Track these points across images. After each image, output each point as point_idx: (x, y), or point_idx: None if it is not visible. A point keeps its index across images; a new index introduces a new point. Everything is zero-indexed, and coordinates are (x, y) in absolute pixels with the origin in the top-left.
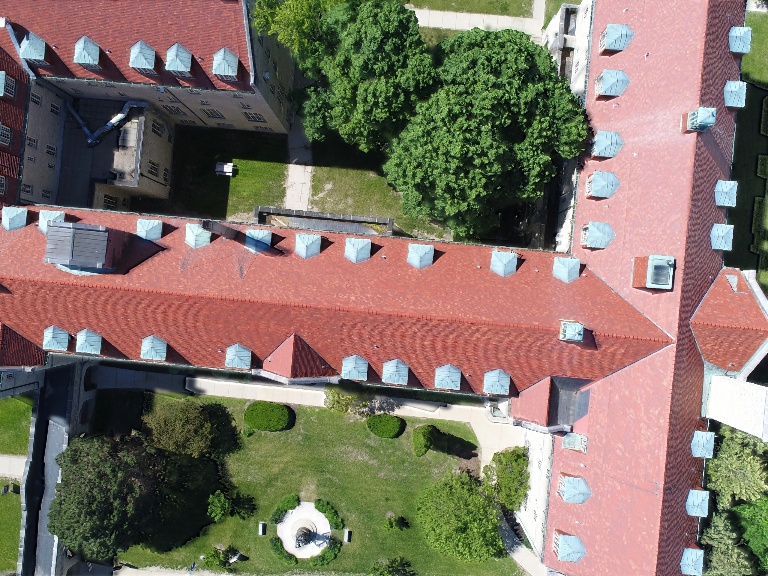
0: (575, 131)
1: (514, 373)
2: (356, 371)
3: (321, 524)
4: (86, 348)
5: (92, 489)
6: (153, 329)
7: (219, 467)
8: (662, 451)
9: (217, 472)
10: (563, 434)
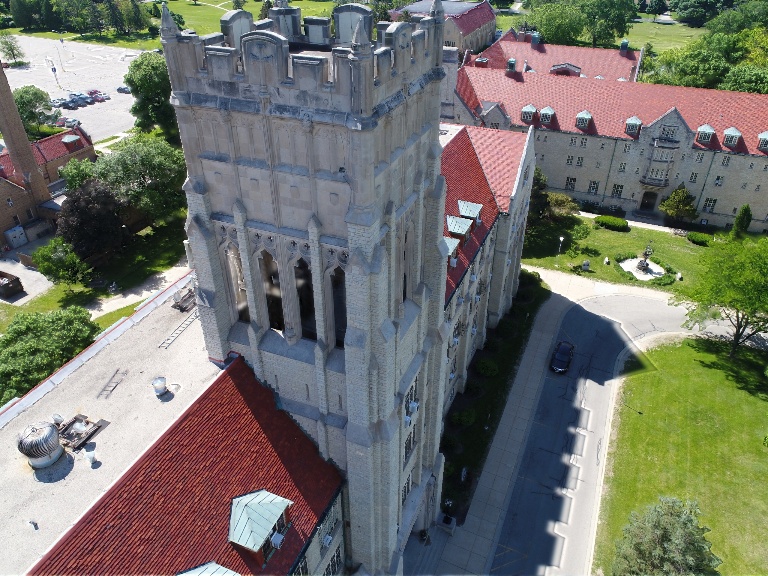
0: None
1: None
2: (708, 128)
3: (656, 268)
4: (546, 111)
5: None
6: (589, 106)
7: None
8: None
9: None
10: None
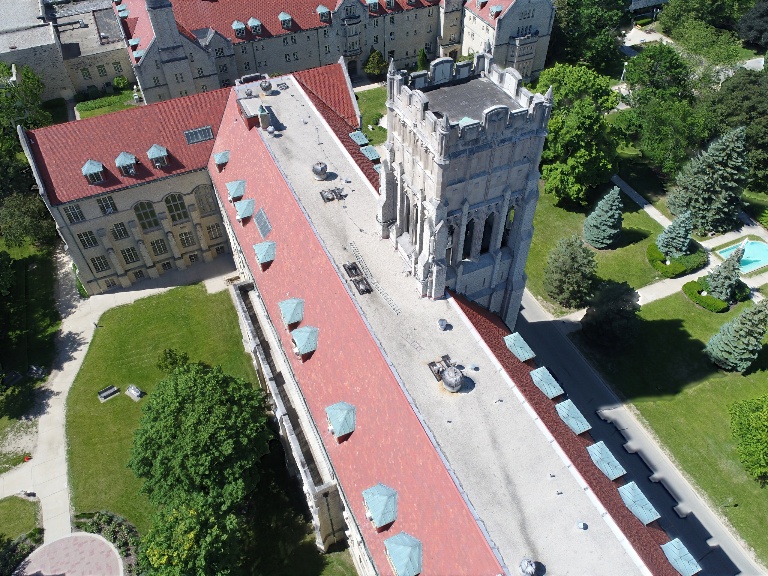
0: None
1: None
2: None
3: None
4: (254, 23)
5: None
6: (282, 7)
7: None
8: None
9: None
10: (466, 1)
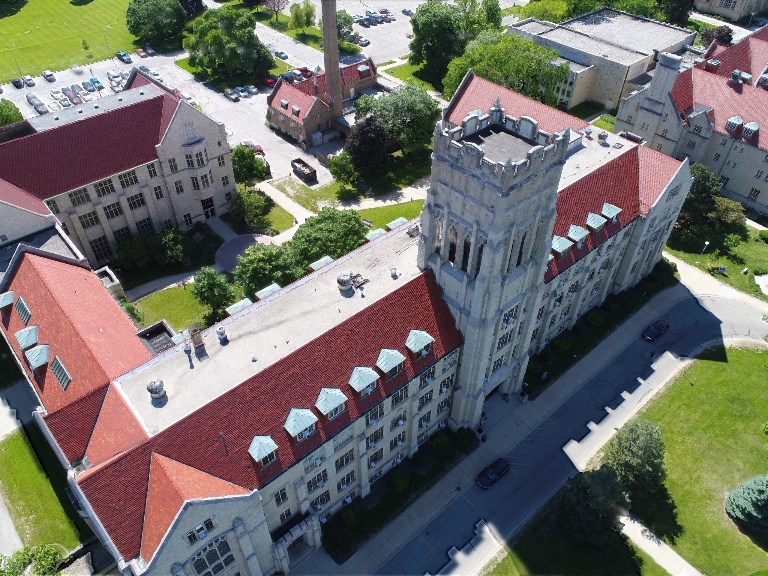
0: None
1: None
2: None
3: None
4: (751, 126)
5: (706, 169)
6: None
7: None
8: None
9: None
10: None
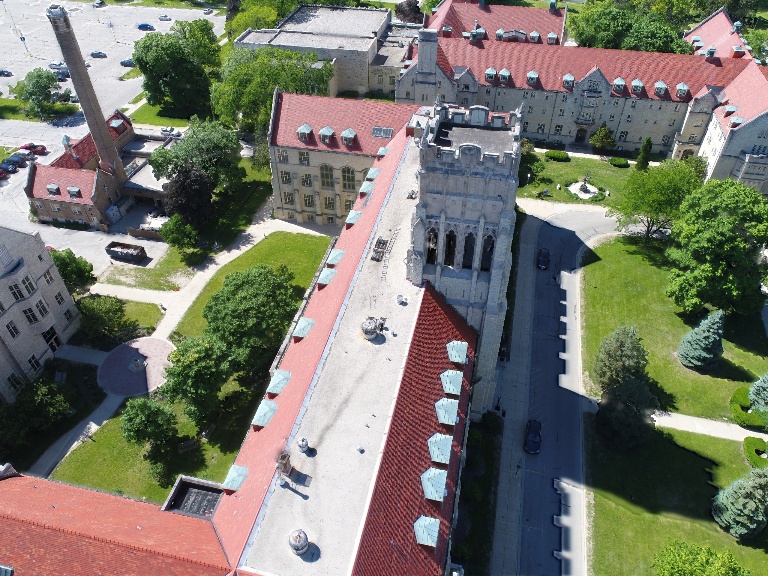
0: (690, 44)
1: (689, 84)
2: (621, 81)
3: None
4: (504, 73)
5: None
6: (535, 66)
7: (532, 169)
8: (762, 77)
9: (531, 170)
10: None
